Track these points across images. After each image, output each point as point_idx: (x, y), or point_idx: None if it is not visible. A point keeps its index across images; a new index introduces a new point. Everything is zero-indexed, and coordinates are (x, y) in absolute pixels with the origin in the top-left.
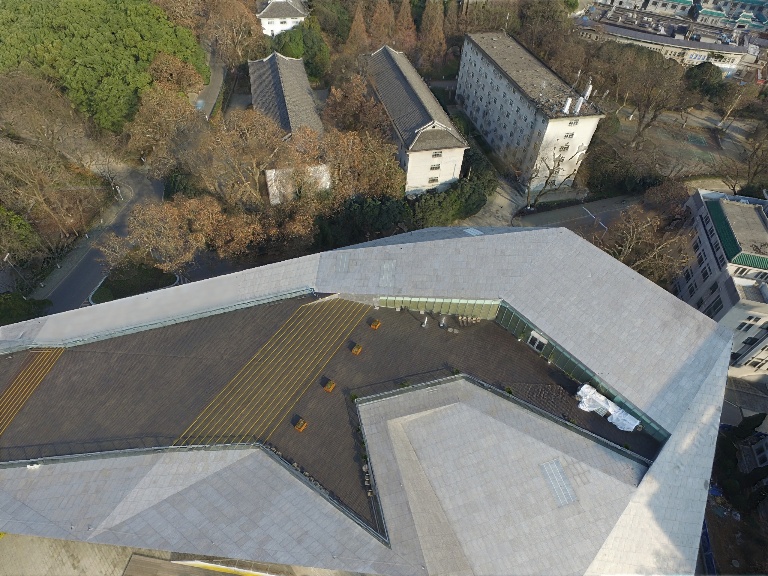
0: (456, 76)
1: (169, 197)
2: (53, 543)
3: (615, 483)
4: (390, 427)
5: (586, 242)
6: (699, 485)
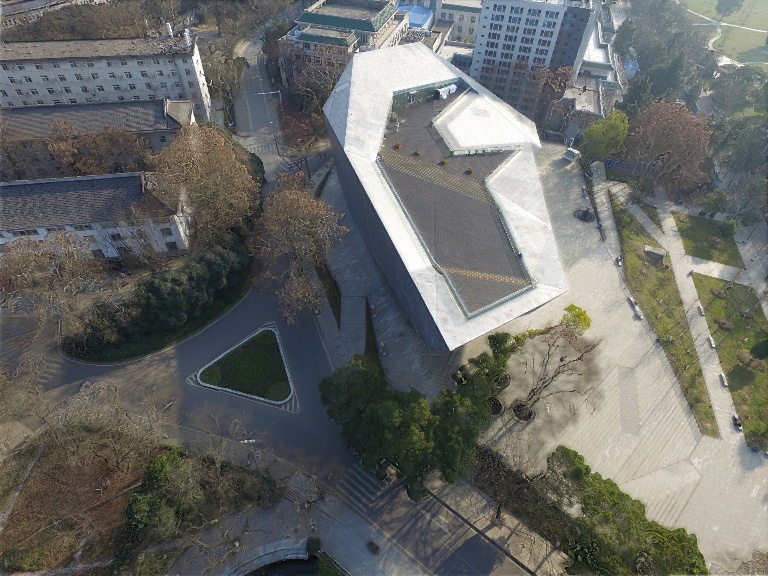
0: None
1: (124, 347)
2: None
3: (479, 99)
4: None
5: (366, 52)
6: None
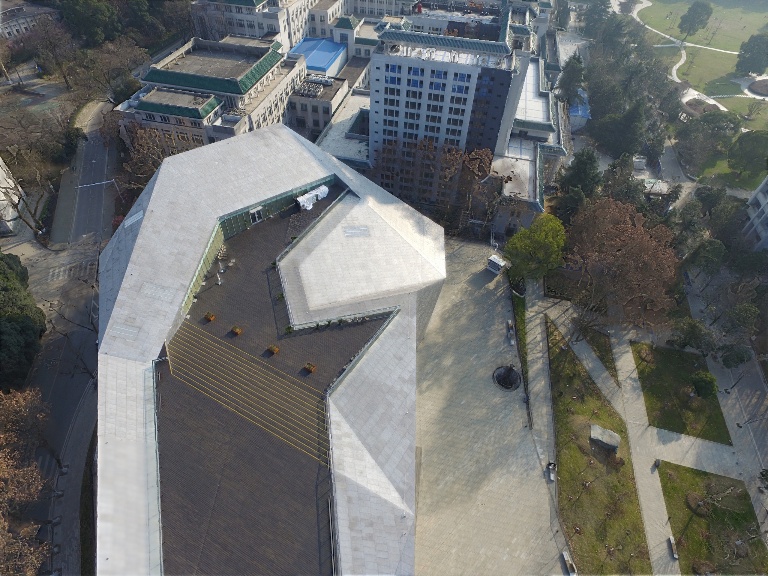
0: None
1: None
2: None
3: (358, 207)
4: None
5: (185, 153)
6: (360, 177)
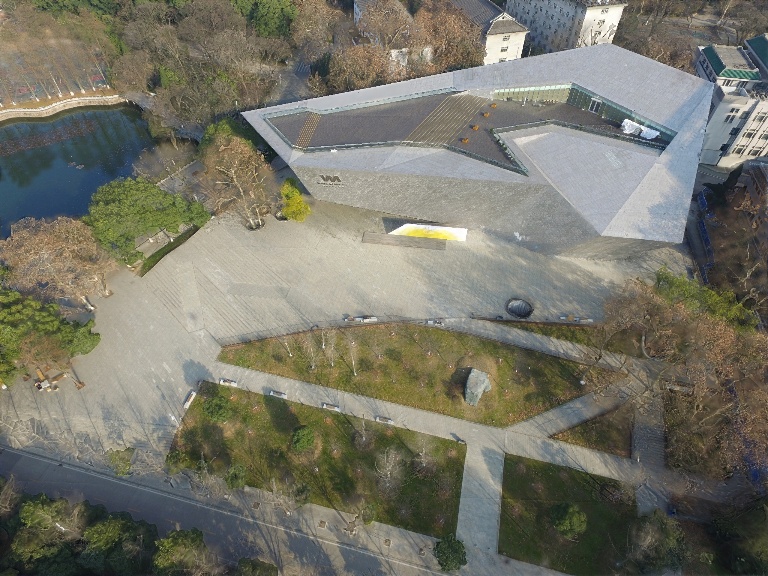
0: (503, 3)
1: None
2: (317, 229)
3: (646, 156)
4: (515, 142)
5: (622, 49)
6: (694, 155)
